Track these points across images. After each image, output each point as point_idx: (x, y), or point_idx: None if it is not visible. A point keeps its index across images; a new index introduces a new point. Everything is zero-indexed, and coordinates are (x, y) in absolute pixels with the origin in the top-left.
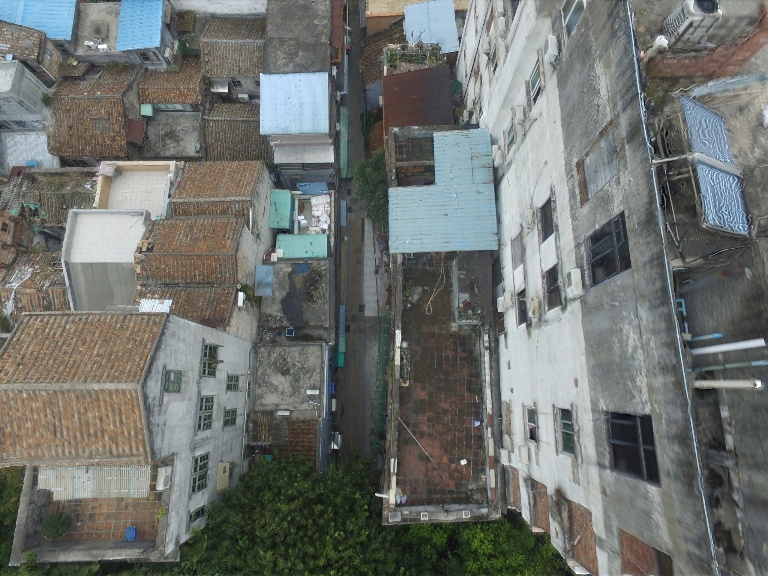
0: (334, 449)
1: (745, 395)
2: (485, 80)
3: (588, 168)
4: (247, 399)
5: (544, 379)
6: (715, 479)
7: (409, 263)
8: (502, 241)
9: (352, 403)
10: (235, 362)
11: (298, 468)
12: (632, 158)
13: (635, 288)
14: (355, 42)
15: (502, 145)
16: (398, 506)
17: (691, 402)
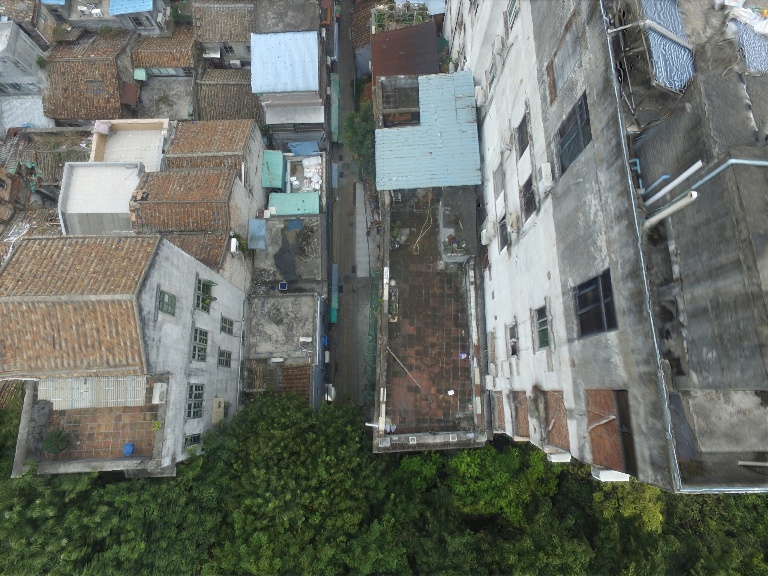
0: (328, 401)
1: (687, 220)
2: (468, 26)
3: (556, 66)
4: (241, 347)
5: (522, 289)
6: (666, 315)
7: (397, 206)
8: (485, 178)
9: (346, 360)
10: (229, 306)
11: (291, 403)
12: (591, 36)
13: (595, 157)
14: (345, 13)
15: (484, 85)
16: (388, 434)
17: (645, 249)
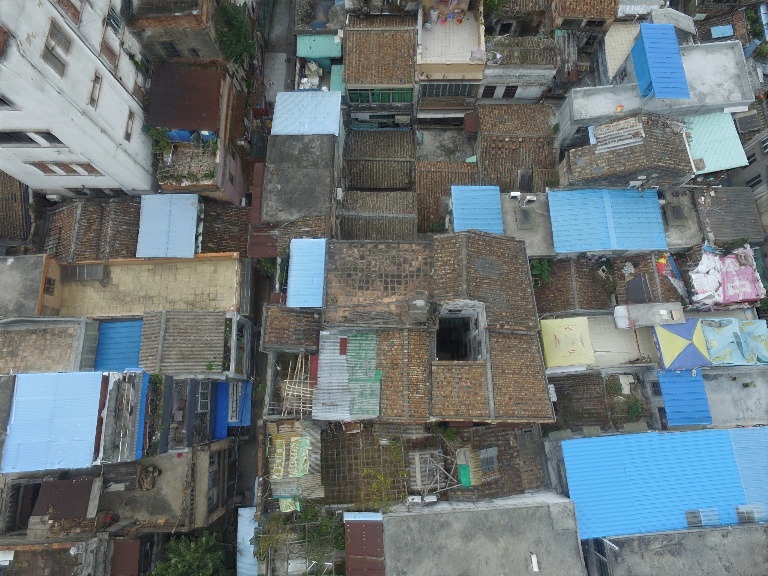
0: None
1: None
2: (97, 1)
3: None
4: None
5: None
6: None
7: None
8: None
9: None
10: None
11: None
12: None
13: None
14: None
15: None
16: None
17: None
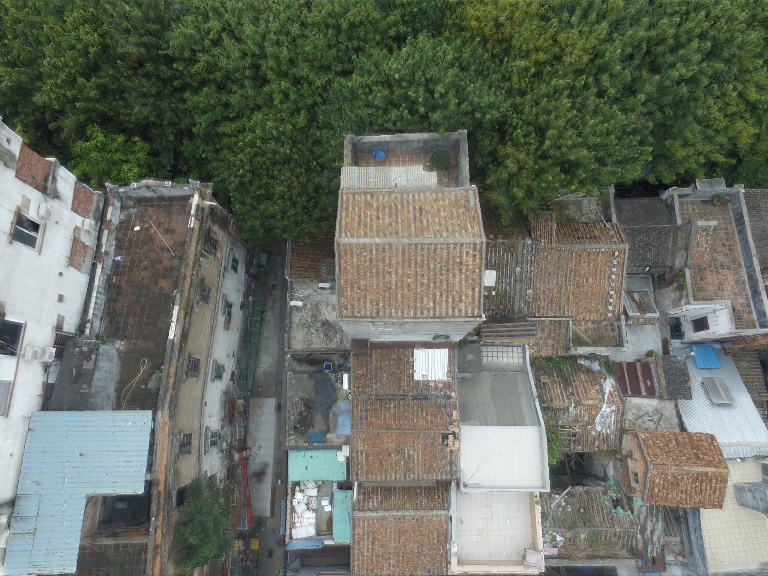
0: None
1: None
2: None
3: None
4: None
5: None
6: None
7: None
8: None
9: None
10: None
11: None
12: None
13: None
14: None
15: None
16: None
17: None
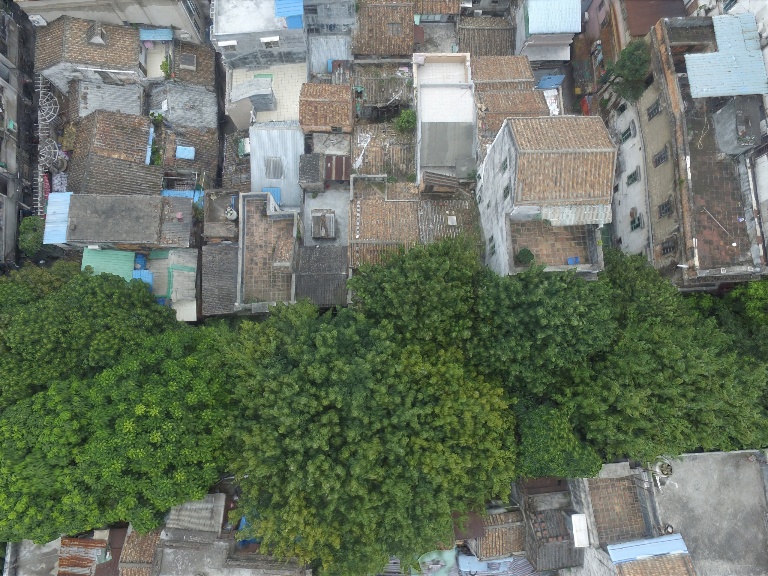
0: None
1: None
2: None
3: None
4: None
5: None
6: None
7: None
8: None
9: None
10: None
11: None
12: None
13: None
14: None
15: (767, 22)
16: None
17: None
